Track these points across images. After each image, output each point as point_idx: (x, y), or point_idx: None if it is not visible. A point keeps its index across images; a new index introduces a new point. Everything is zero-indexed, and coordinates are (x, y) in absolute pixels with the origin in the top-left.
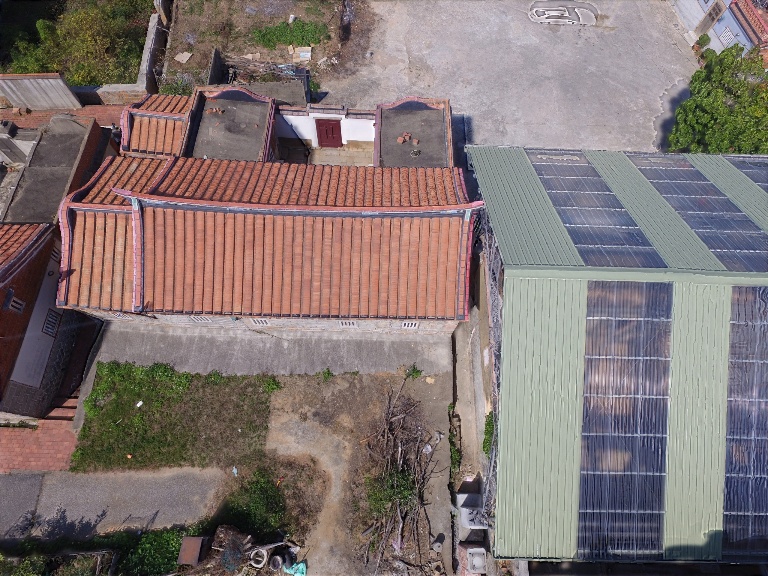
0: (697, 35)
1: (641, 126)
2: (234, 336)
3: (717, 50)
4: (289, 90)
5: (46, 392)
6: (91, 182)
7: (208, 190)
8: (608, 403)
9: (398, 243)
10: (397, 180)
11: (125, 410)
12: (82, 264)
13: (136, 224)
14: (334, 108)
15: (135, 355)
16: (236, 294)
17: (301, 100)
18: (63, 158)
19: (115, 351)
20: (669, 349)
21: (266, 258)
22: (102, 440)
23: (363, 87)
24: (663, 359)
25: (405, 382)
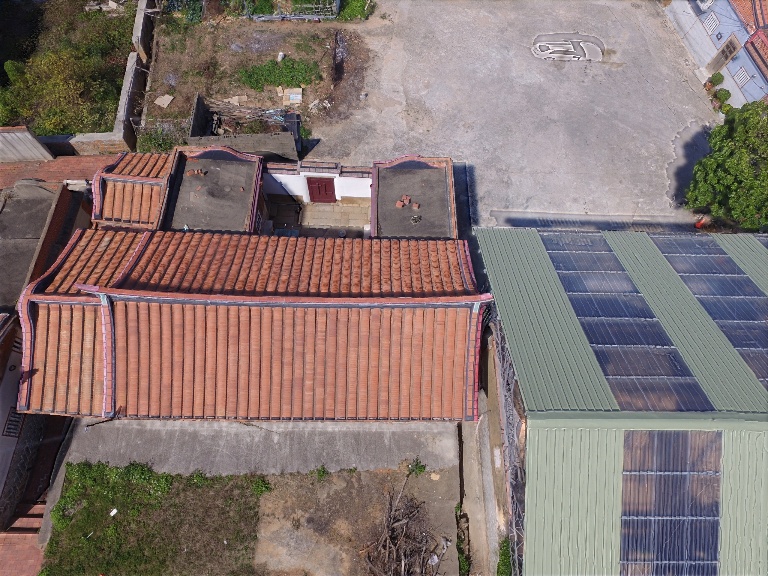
0: (709, 72)
1: (653, 174)
2: (219, 429)
3: (731, 90)
4: (278, 142)
5: (8, 500)
6: (57, 265)
7: (187, 275)
8: (648, 570)
9: (399, 336)
10: (397, 257)
11: (97, 520)
12: (46, 363)
13: (106, 320)
14: (327, 167)
15: (109, 454)
16: (219, 396)
17: (291, 151)
18: (29, 228)
19: (86, 450)
20: (718, 507)
21: (252, 354)
22: (71, 558)
23: (358, 133)
24: (711, 519)
25: (407, 479)
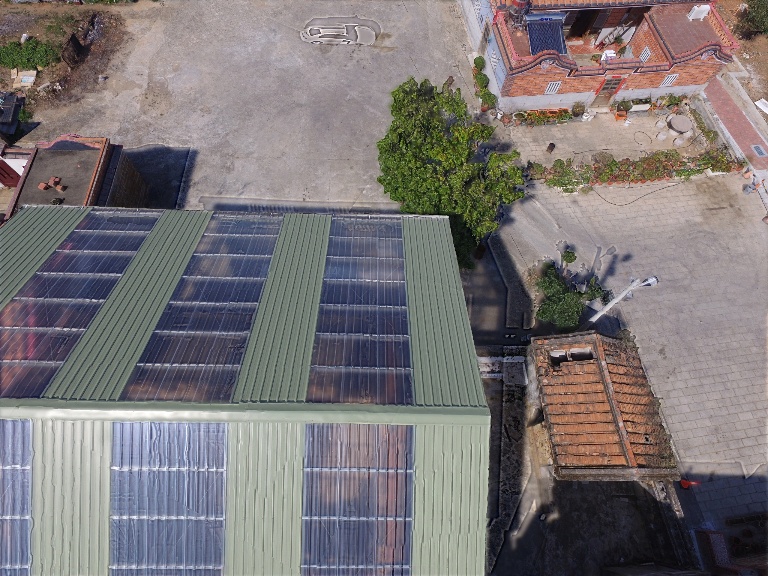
0: None
1: None
2: None
3: (490, 74)
4: None
5: None
6: None
7: None
8: None
9: None
10: None
11: None
12: None
13: None
14: None
15: None
16: None
17: None
18: None
19: None
20: (27, 505)
21: None
22: None
23: (84, 116)
24: (18, 518)
25: None
